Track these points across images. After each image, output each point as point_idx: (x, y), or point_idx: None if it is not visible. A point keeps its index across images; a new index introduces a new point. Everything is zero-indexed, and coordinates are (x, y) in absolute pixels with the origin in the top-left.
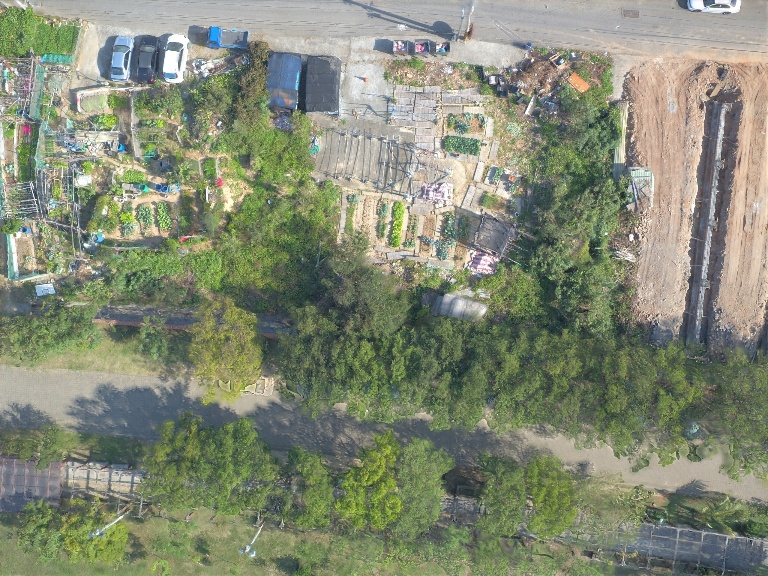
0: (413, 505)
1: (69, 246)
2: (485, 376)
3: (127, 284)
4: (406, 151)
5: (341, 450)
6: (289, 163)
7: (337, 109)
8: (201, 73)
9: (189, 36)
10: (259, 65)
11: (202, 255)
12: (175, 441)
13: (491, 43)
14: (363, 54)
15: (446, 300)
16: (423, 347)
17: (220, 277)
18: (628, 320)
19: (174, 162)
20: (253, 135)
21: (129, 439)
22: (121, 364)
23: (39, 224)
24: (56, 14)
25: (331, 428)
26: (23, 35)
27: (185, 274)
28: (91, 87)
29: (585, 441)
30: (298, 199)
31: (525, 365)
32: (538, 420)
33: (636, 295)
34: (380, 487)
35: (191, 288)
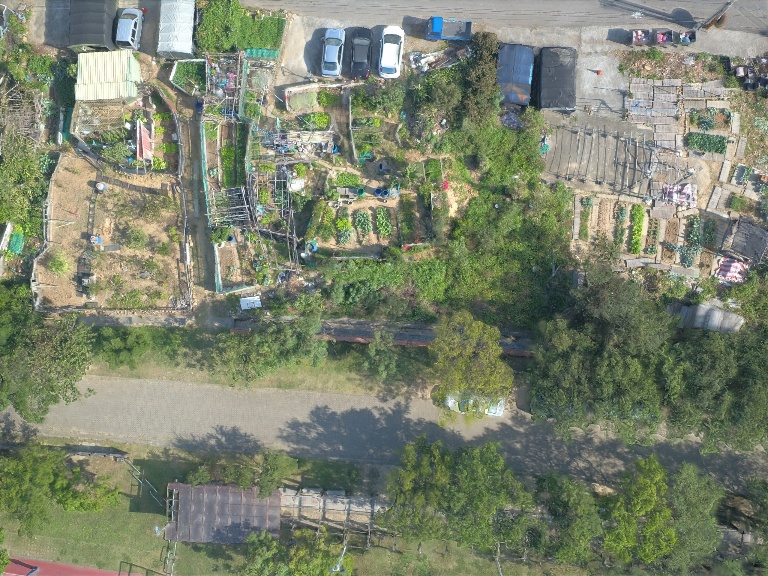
0: (690, 537)
1: (278, 256)
2: (765, 395)
3: (345, 296)
4: (645, 150)
5: (577, 474)
6: (519, 164)
7: (575, 105)
8: (419, 67)
9: (404, 27)
10: (489, 58)
11: (423, 264)
12: (420, 468)
13: (736, 31)
14: (595, 45)
15: (700, 311)
16: (691, 364)
17: (443, 288)
18: None
19: (392, 164)
20: (480, 134)
21: (344, 463)
22: (334, 382)
23: (245, 232)
24: (257, 5)
25: (566, 450)
26: (230, 28)
27: (406, 285)
28: (298, 84)
29: None
30: (533, 203)
31: None
32: None
33: None
34: (655, 518)
35: (412, 300)
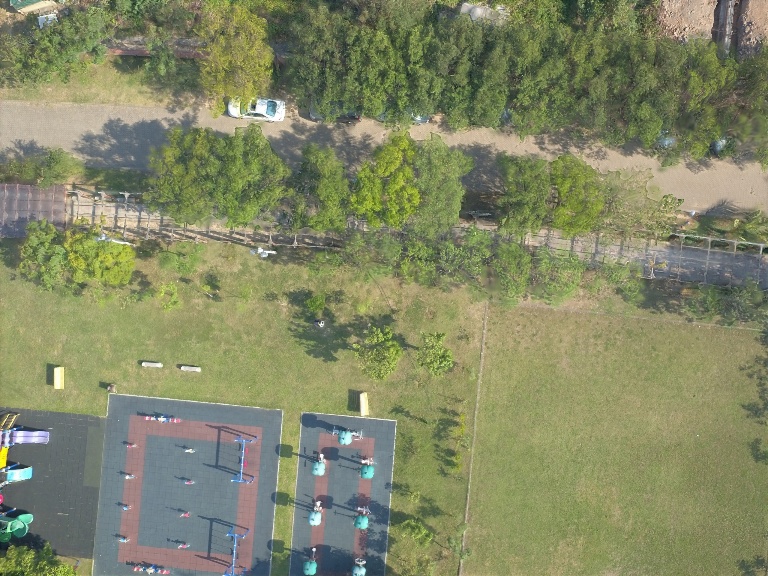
0: (433, 196)
1: None
2: (507, 64)
3: (133, 6)
4: None
5: None
6: None
7: None
8: None
9: None
10: None
11: None
12: (184, 143)
13: None
14: None
15: (464, 9)
16: (442, 41)
17: (229, 1)
18: (654, 33)
19: None
20: None
21: (136, 173)
22: (127, 96)
23: None
24: None
25: (345, 155)
26: None
27: None
28: None
29: (612, 136)
30: None
31: (549, 56)
32: (563, 112)
33: (662, 6)
34: (398, 176)
35: (199, 13)
